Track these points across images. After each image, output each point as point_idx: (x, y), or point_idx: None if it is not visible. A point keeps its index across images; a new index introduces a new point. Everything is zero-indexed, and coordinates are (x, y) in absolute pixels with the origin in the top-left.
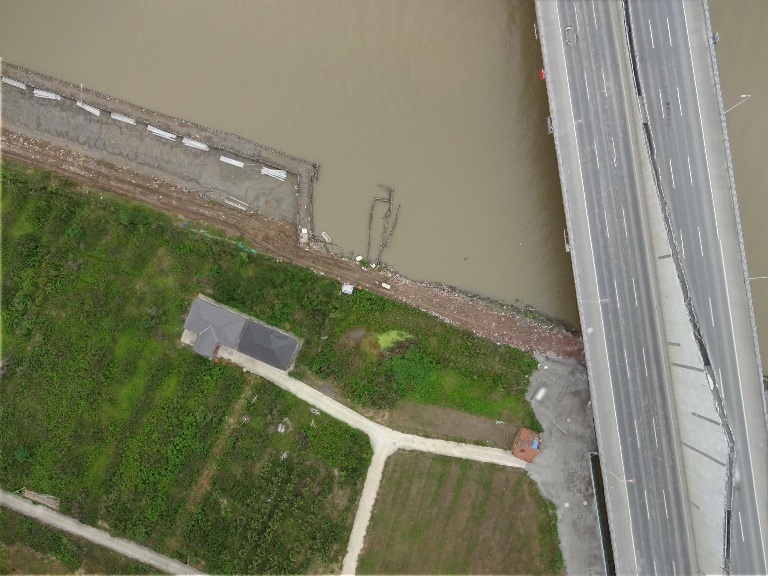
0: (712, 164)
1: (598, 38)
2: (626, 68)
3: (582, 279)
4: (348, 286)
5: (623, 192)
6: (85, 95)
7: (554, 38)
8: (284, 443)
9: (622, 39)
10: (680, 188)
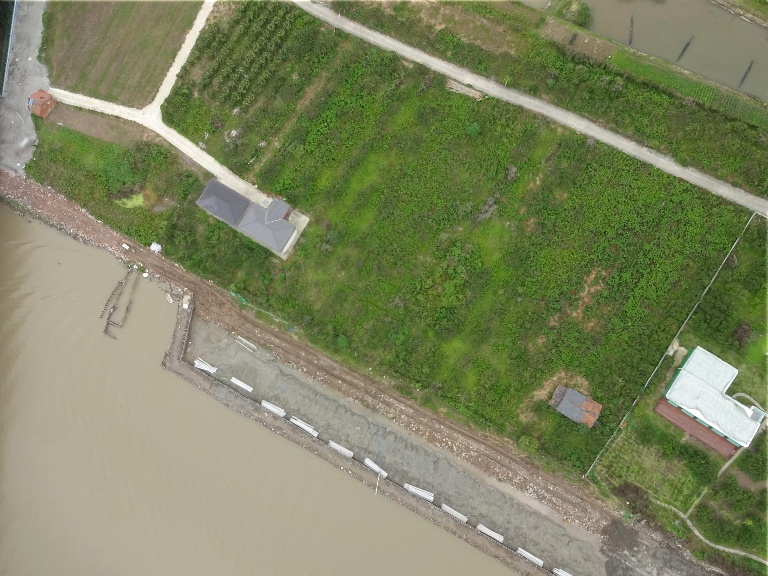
0: None
1: None
2: None
3: None
4: (154, 249)
5: None
6: (374, 481)
7: None
8: (234, 121)
9: None
10: None
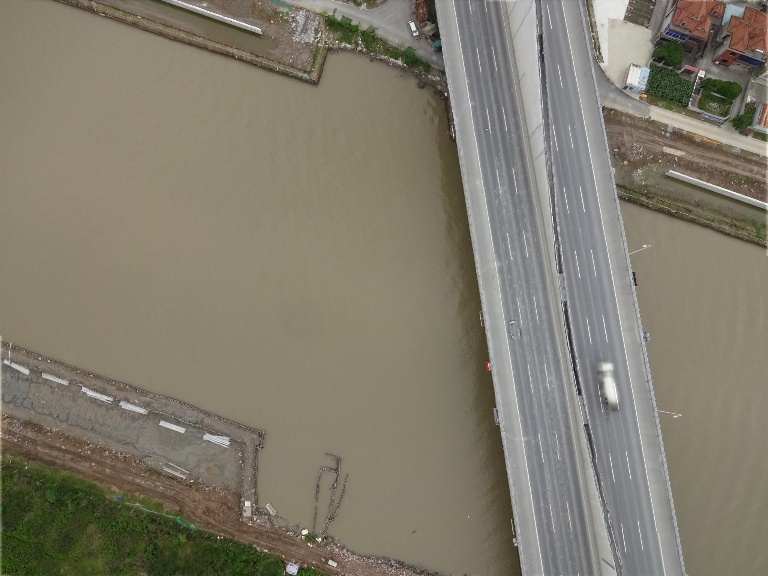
0: (648, 458)
1: (540, 333)
2: (567, 365)
3: (530, 575)
4: (293, 567)
5: (567, 486)
6: (14, 354)
7: (499, 331)
8: None
9: (562, 337)
10: (620, 482)
